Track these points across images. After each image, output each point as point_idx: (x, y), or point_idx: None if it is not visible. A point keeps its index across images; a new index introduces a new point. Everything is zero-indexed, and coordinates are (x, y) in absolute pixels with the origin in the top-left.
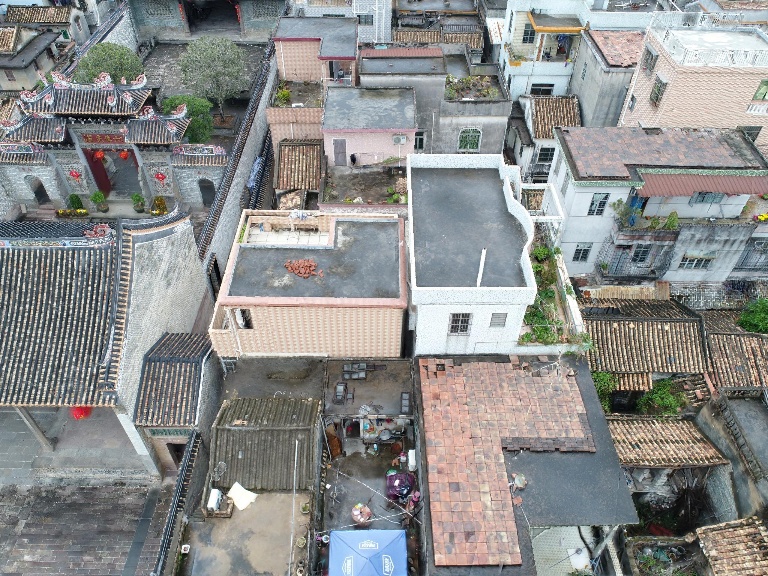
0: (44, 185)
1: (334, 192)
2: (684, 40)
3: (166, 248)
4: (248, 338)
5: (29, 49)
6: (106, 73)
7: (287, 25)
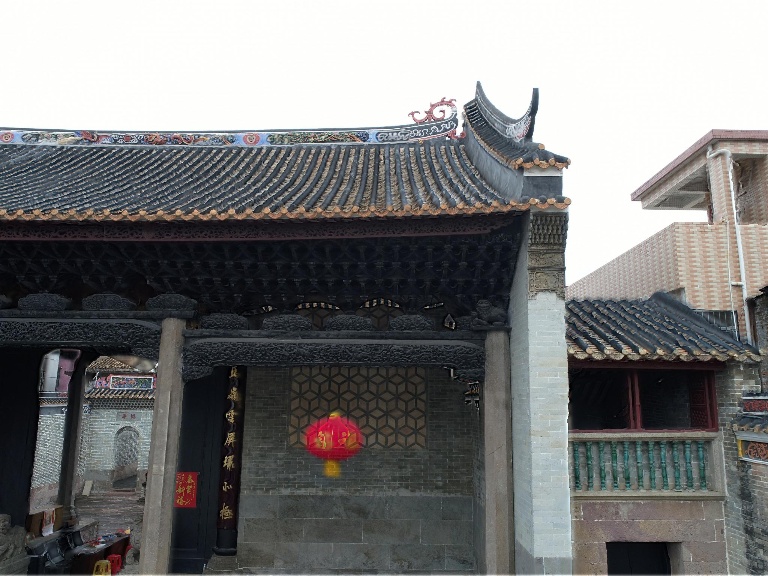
0: (141, 444)
1: None
2: None
3: None
4: (759, 246)
5: None
6: None
7: None
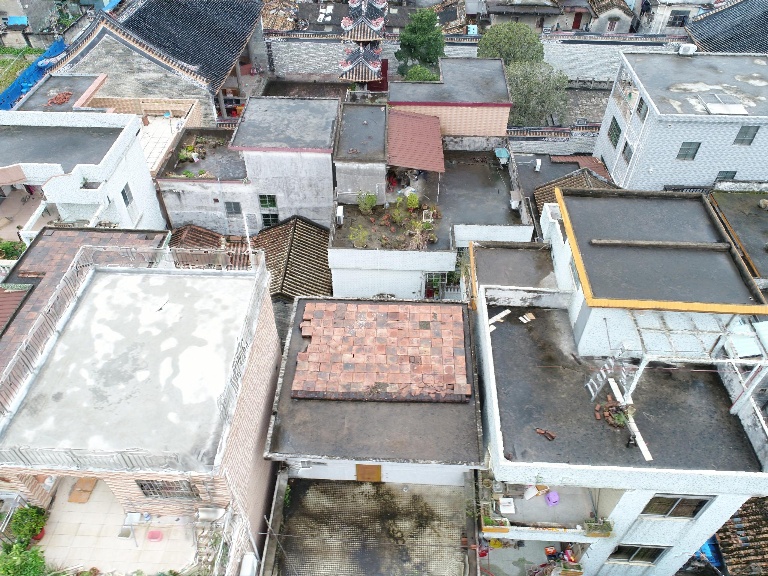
0: None
1: (213, 142)
2: (201, 312)
3: (155, 71)
4: None
5: (522, 8)
6: (363, 2)
7: (477, 63)
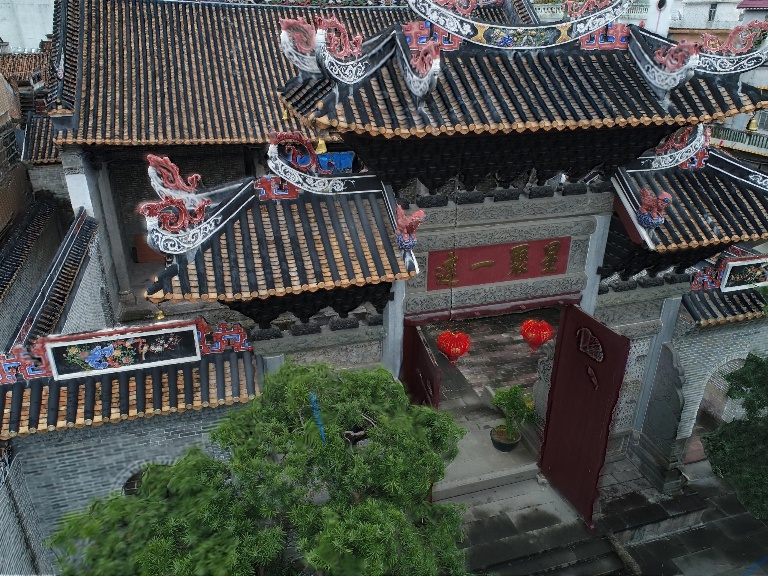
0: None
1: None
2: None
3: None
4: None
5: None
6: None
7: None
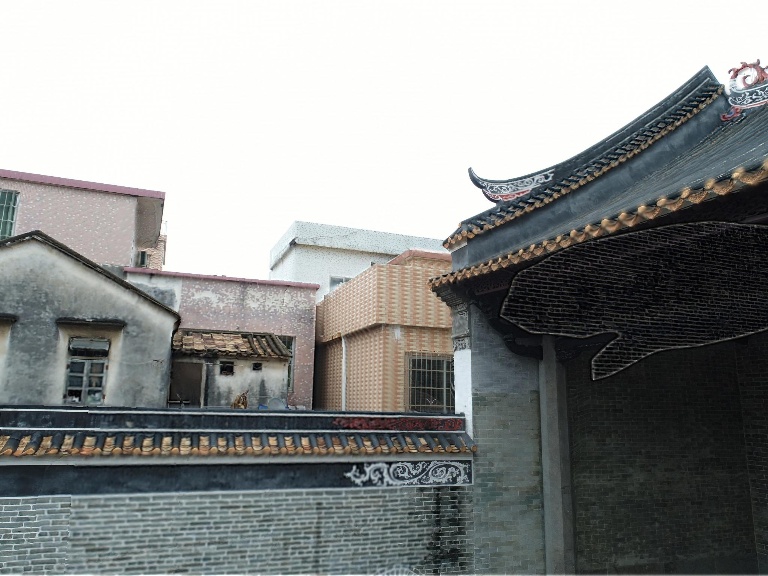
0: None
1: None
2: None
3: None
4: None
5: None
6: None
7: None
